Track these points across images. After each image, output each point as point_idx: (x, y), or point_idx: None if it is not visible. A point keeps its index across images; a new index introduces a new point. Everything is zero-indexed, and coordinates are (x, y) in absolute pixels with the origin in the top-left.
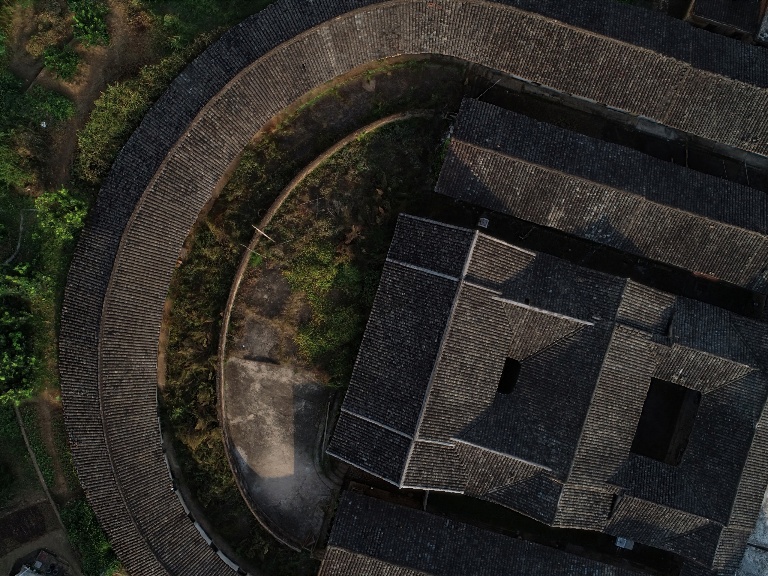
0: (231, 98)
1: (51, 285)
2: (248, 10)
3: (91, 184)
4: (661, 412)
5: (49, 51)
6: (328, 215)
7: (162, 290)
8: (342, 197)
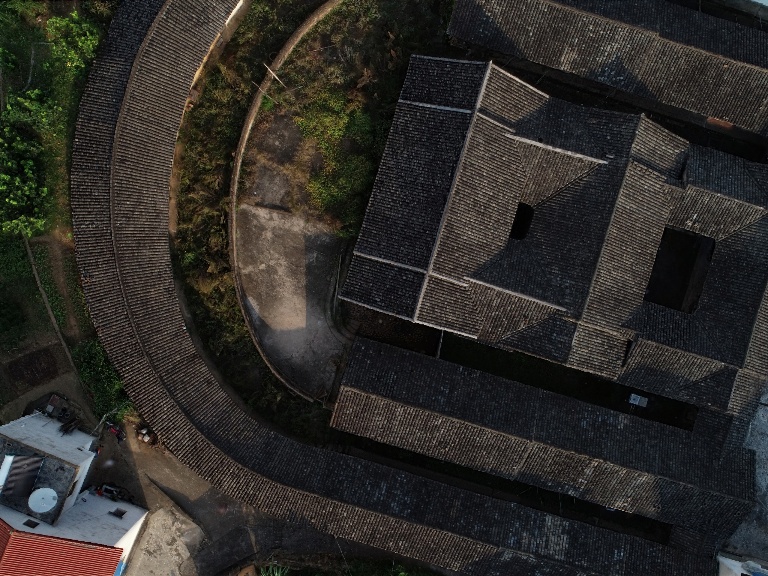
0: None
1: (62, 120)
2: None
3: (102, 19)
4: (674, 270)
5: None
6: (339, 62)
7: (174, 122)
8: (353, 45)
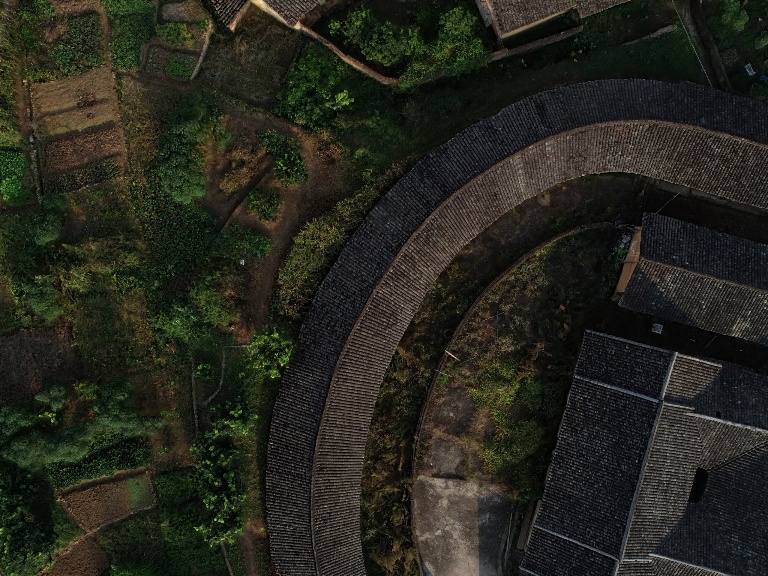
0: (429, 231)
1: (253, 419)
2: (430, 136)
3: (288, 317)
4: None
5: (255, 196)
6: (509, 331)
7: (366, 422)
8: (521, 312)
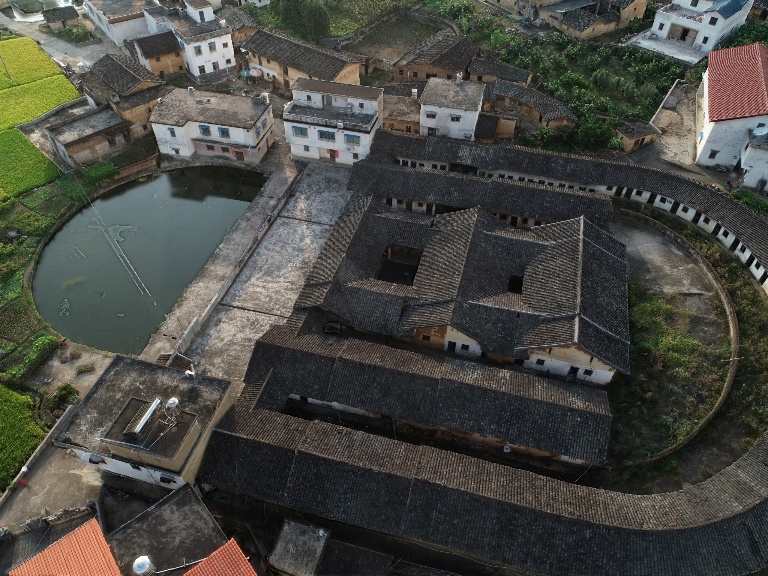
0: None
1: None
2: None
3: None
4: None
5: None
6: None
7: None
8: None
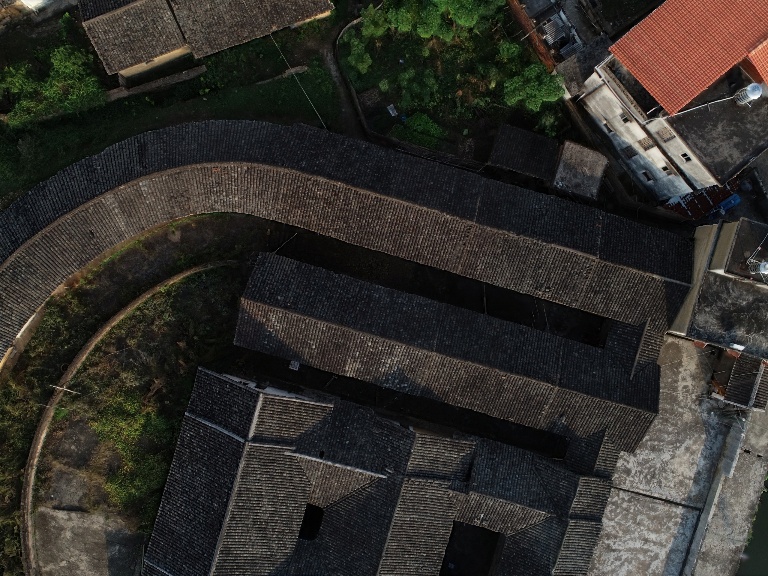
0: (16, 269)
1: None
2: (45, 171)
3: None
4: (479, 545)
5: None
6: (135, 365)
7: None
8: (149, 347)
